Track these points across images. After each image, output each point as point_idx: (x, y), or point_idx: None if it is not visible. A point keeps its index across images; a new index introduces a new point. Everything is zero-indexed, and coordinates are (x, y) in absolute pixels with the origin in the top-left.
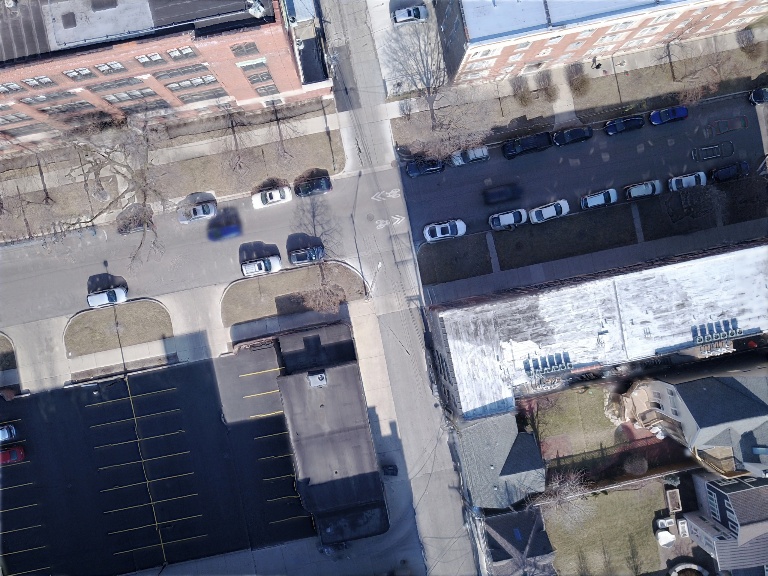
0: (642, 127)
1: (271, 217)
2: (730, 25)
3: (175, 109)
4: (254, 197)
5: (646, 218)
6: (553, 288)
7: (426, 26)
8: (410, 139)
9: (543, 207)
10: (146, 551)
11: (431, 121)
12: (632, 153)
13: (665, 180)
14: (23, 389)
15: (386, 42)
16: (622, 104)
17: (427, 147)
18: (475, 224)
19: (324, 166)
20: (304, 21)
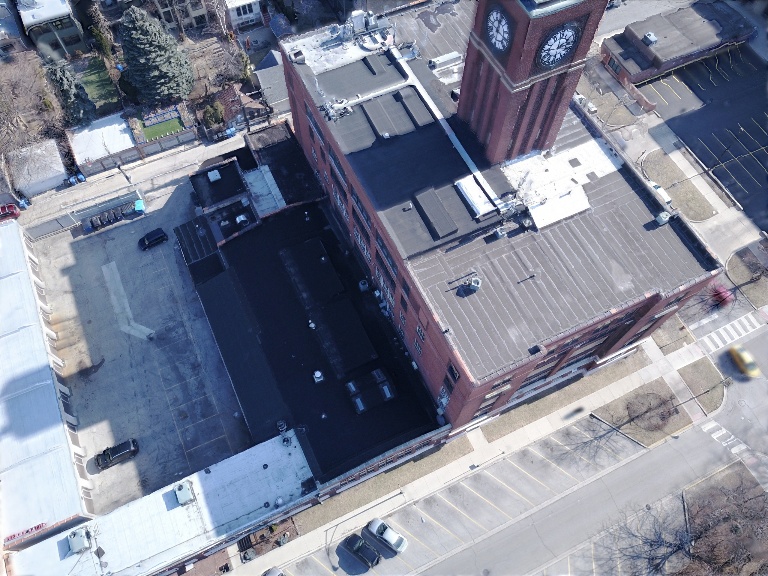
0: None
1: None
2: None
3: None
4: None
5: None
6: None
7: None
8: None
9: None
10: None
11: None
12: None
13: None
14: (761, 238)
15: None
16: None
17: None
18: None
19: None
20: None
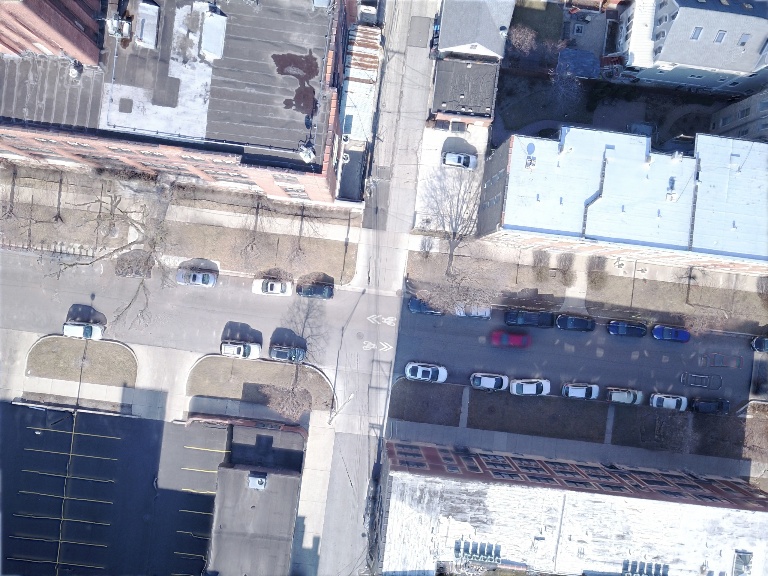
0: (643, 337)
1: (266, 305)
2: (754, 272)
3: (207, 182)
4: (256, 282)
5: (619, 422)
6: (506, 481)
7: (472, 175)
8: (422, 275)
9: (526, 382)
10: None
11: (447, 265)
12: (626, 357)
13: (648, 392)
14: None
15: (429, 177)
16: (631, 308)
17: (433, 300)
18: (457, 375)
19: (332, 274)
20: (357, 140)
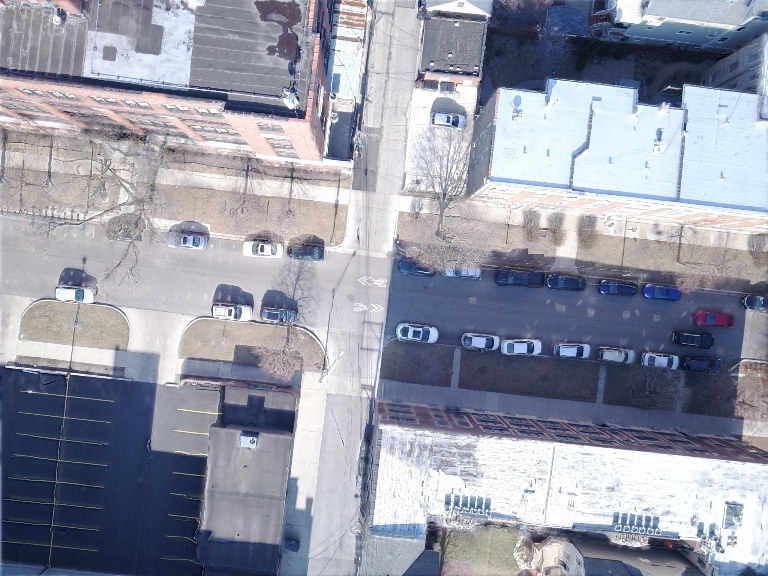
0: (634, 296)
1: (257, 267)
2: (745, 229)
3: (196, 142)
4: (246, 244)
5: (611, 382)
6: (496, 434)
7: (461, 135)
8: (412, 236)
9: (517, 341)
10: (34, 548)
11: (437, 226)
12: (617, 316)
13: (640, 352)
14: None
15: (418, 138)
16: (622, 267)
17: (422, 257)
18: (448, 336)
19: (322, 235)
20: (345, 99)
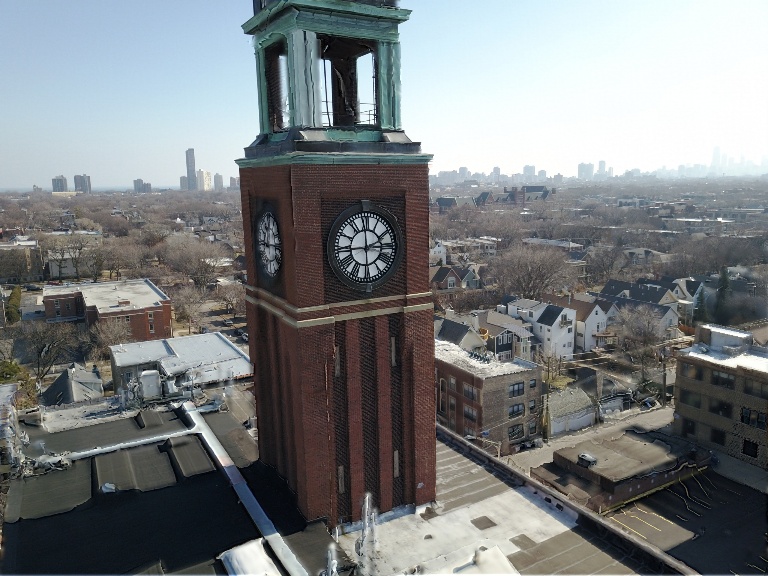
0: None
1: None
2: None
3: None
4: None
5: None
6: None
7: None
8: None
9: None
10: None
11: None
12: None
13: None
14: None
15: None
16: None
17: None
18: None
19: None
20: None
